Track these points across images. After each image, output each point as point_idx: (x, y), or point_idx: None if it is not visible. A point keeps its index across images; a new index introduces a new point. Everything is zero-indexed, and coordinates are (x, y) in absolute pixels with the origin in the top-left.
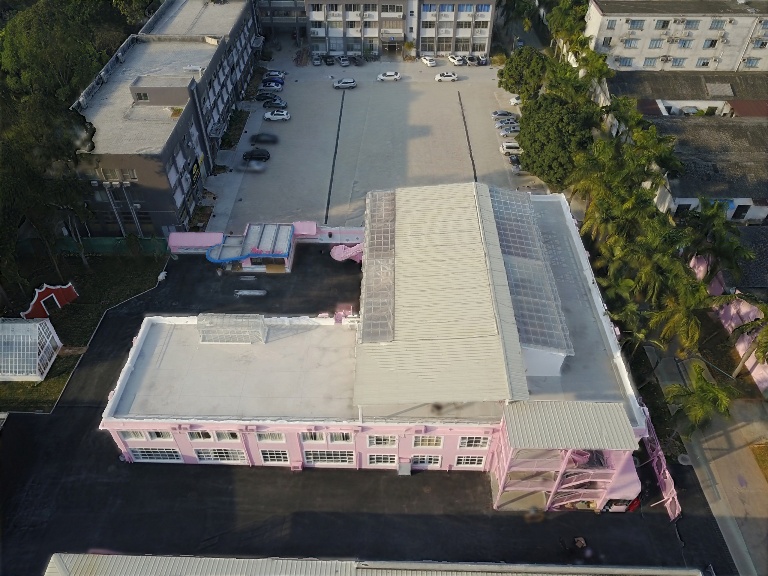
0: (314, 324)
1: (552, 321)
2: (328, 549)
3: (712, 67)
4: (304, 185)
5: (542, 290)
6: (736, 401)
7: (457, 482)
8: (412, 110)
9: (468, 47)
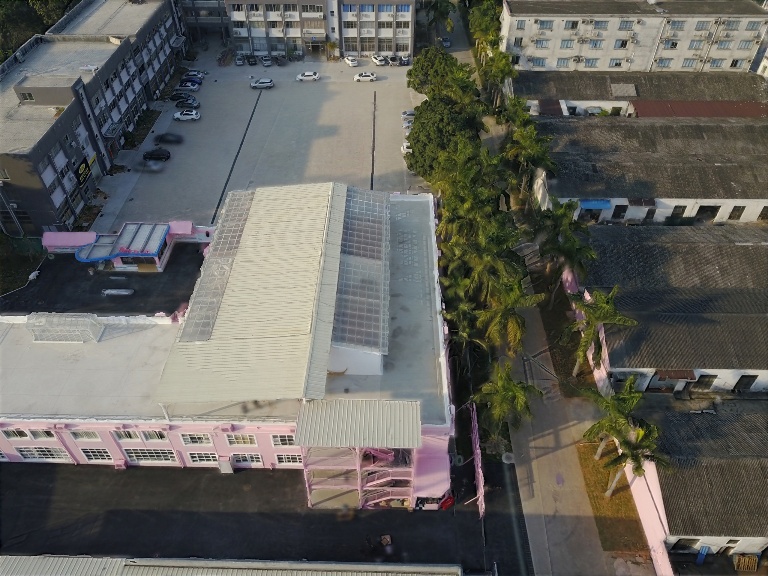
0: (151, 323)
1: (374, 320)
2: (134, 547)
3: (625, 67)
4: (199, 185)
5: (373, 289)
6: (573, 400)
7: (278, 480)
8: (324, 110)
9: (391, 47)
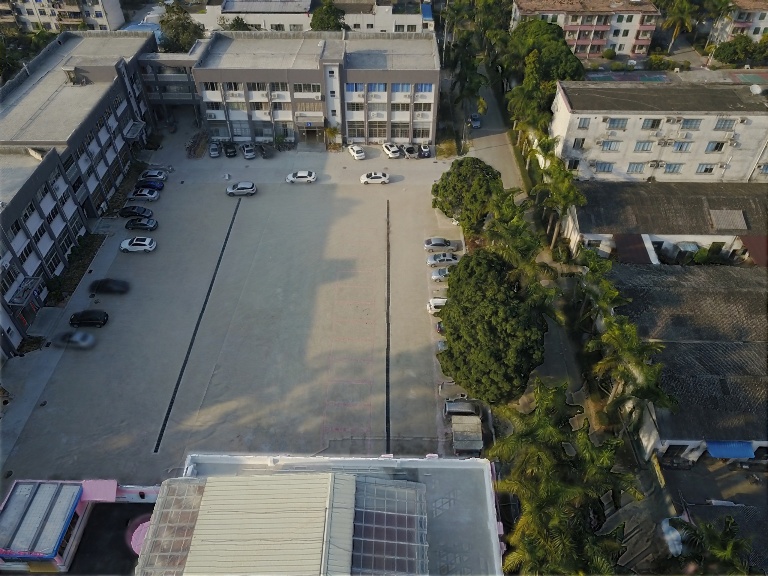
0: None
1: None
2: None
3: (717, 174)
4: (144, 372)
5: None
6: None
7: None
8: (321, 233)
9: (408, 133)
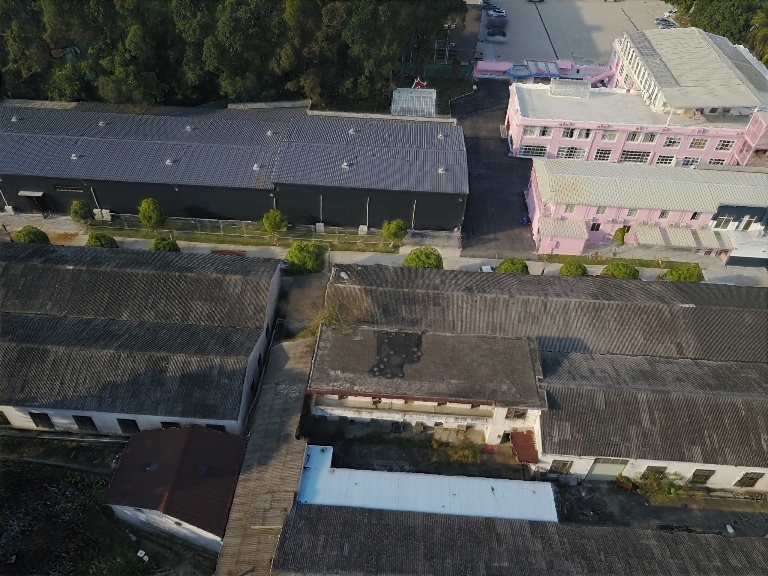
0: (613, 92)
1: (767, 86)
2: None
3: None
4: (537, 52)
5: (756, 75)
6: None
7: None
8: (593, 16)
9: None
